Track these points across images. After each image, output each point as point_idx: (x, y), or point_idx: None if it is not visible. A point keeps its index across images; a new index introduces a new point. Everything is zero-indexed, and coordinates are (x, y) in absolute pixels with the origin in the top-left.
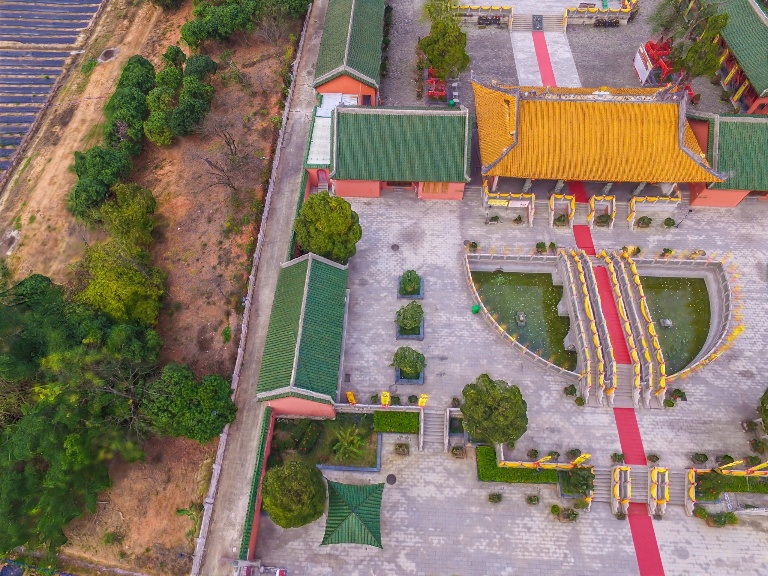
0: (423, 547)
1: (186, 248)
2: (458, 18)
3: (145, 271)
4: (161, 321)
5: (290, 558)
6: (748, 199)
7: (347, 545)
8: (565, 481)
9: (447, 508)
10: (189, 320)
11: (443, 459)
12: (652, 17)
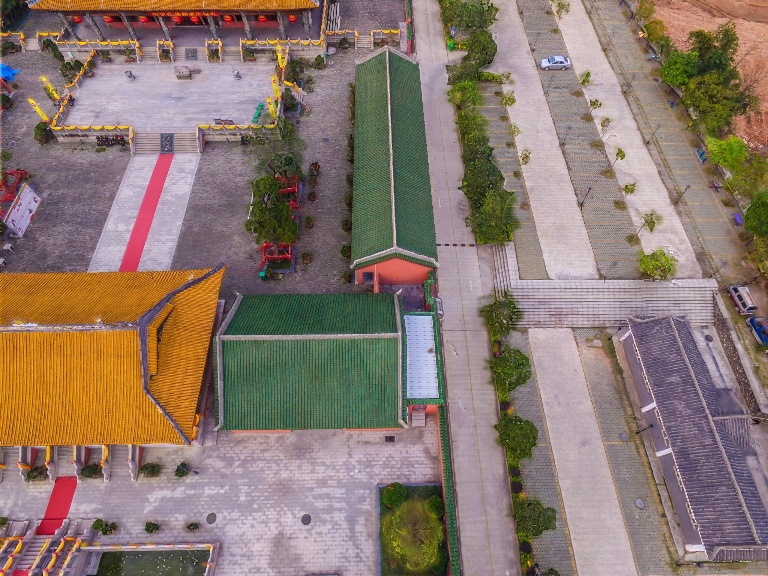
0: None
1: None
2: (72, 138)
3: None
4: None
5: None
6: None
7: None
8: None
9: None
10: None
11: None
12: (319, 128)
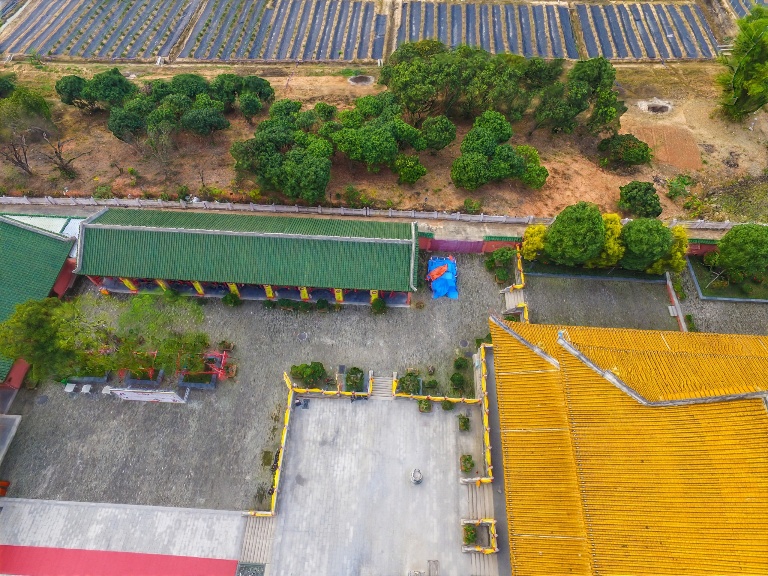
0: None
1: (3, 157)
2: None
3: None
4: None
5: None
6: None
7: None
8: None
9: None
10: None
11: None
12: None
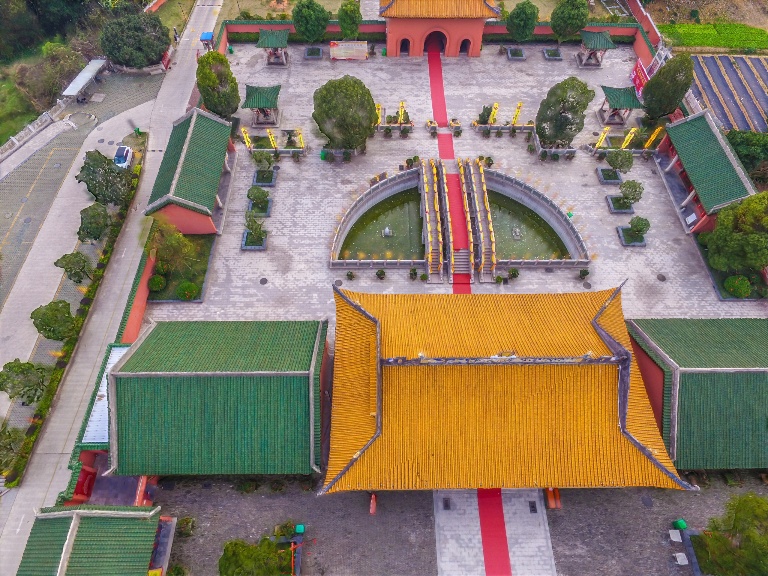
0: None
1: None
2: None
3: None
4: None
5: None
6: None
7: None
8: None
9: None
10: None
11: None
12: None
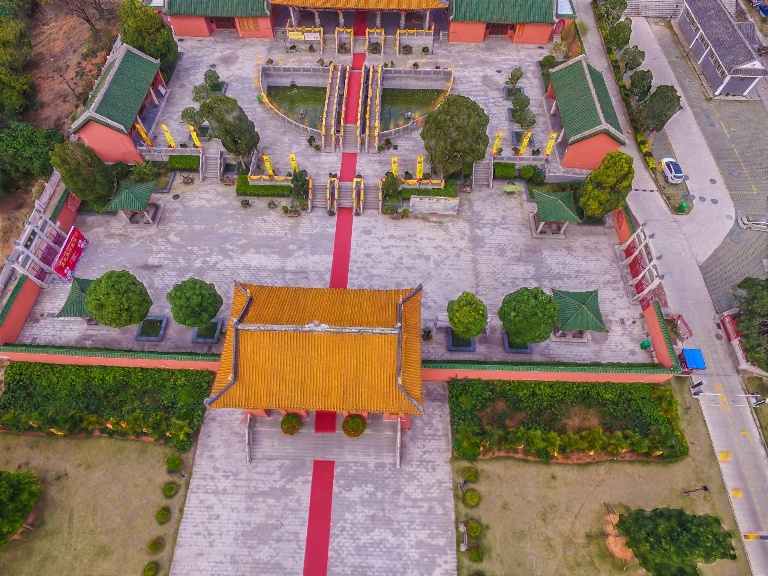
0: (188, 230)
1: (55, 70)
2: None
3: (14, 74)
4: (28, 115)
5: (93, 236)
6: (494, 37)
7: (135, 230)
8: (296, 193)
9: (211, 211)
10: (49, 113)
11: (216, 186)
12: None
